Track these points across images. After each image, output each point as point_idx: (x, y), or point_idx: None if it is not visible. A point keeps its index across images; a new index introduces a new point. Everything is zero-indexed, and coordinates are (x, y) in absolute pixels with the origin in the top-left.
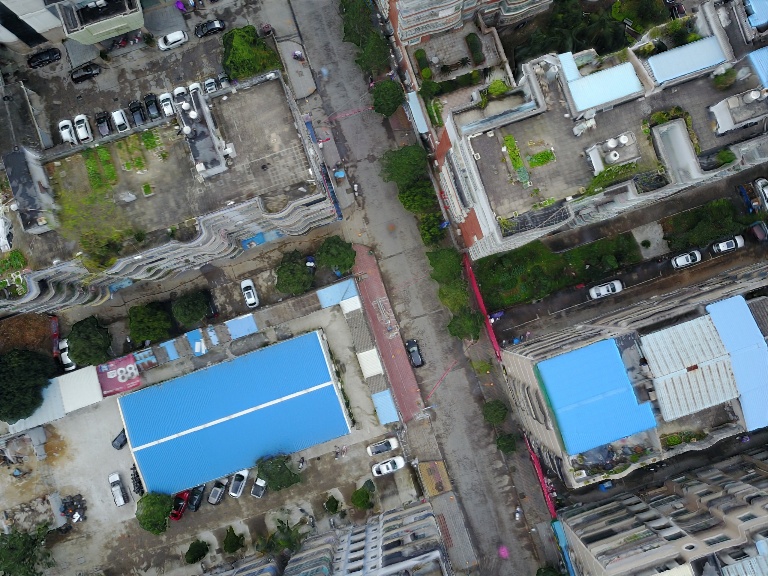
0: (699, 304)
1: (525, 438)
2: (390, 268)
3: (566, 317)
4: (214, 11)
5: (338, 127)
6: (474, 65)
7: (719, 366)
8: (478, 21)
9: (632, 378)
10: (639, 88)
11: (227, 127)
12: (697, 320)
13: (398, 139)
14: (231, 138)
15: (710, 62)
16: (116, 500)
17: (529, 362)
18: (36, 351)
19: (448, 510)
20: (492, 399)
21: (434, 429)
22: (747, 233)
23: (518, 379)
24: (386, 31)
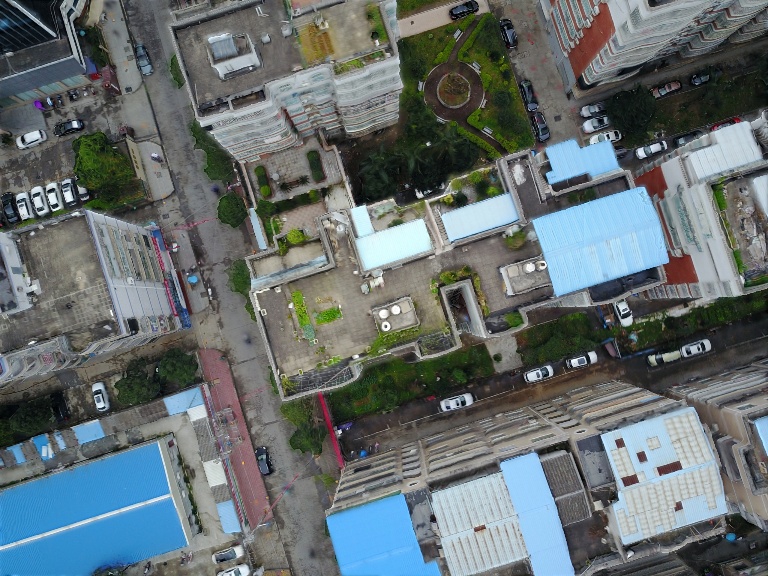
0: (497, 457)
1: None
2: (243, 373)
3: (417, 428)
4: (74, 110)
5: (195, 230)
6: (315, 183)
7: (507, 527)
8: (320, 138)
9: (422, 534)
10: (428, 247)
11: (33, 263)
12: (489, 477)
13: (255, 243)
14: (37, 274)
15: (503, 221)
16: None
17: None
18: None
19: None
20: None
21: (282, 537)
22: (601, 349)
23: None
24: None
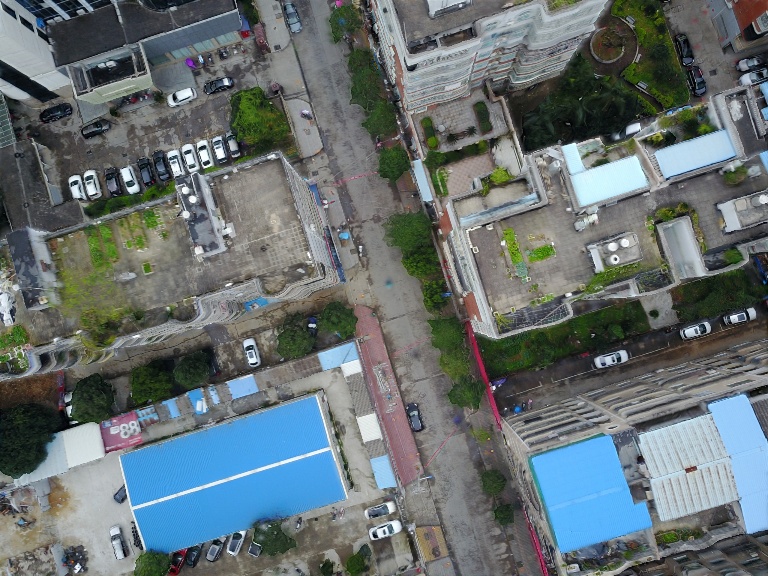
0: (701, 400)
1: (524, 509)
2: (393, 330)
3: (570, 385)
4: (223, 68)
5: (344, 187)
6: (481, 134)
7: (719, 468)
8: (486, 89)
9: (629, 476)
10: (644, 183)
11: (227, 206)
12: (698, 419)
13: (404, 200)
14: (231, 218)
15: (719, 157)
16: (116, 554)
17: (525, 452)
18: (42, 403)
19: (444, 575)
20: (492, 466)
21: (433, 494)
22: (760, 305)
23: (516, 457)
24: (393, 97)
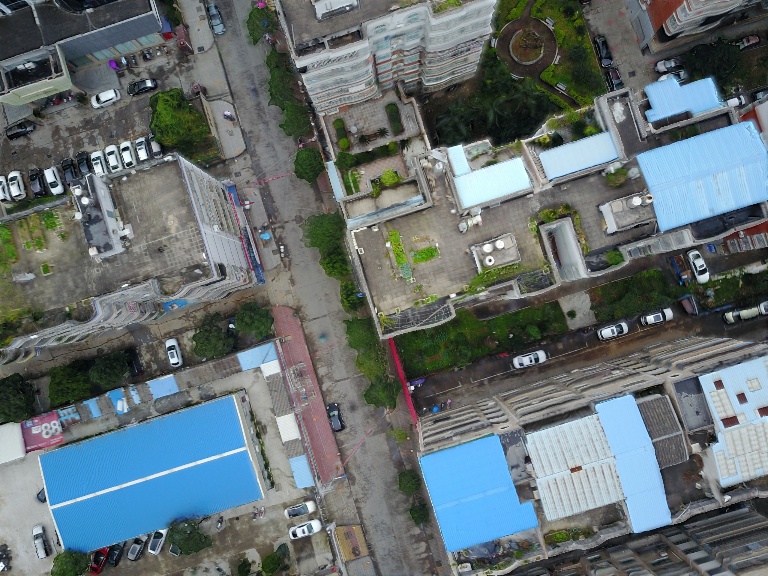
0: (591, 401)
1: None
2: (314, 330)
3: (489, 386)
4: (147, 69)
5: (266, 188)
6: (393, 135)
7: (604, 468)
8: (398, 91)
9: (517, 476)
10: (527, 185)
11: (126, 208)
12: (585, 419)
13: (326, 201)
14: (129, 219)
15: (602, 159)
16: (38, 553)
17: None
18: None
19: (364, 575)
20: (412, 465)
21: (353, 493)
22: (676, 306)
23: None
24: (307, 98)
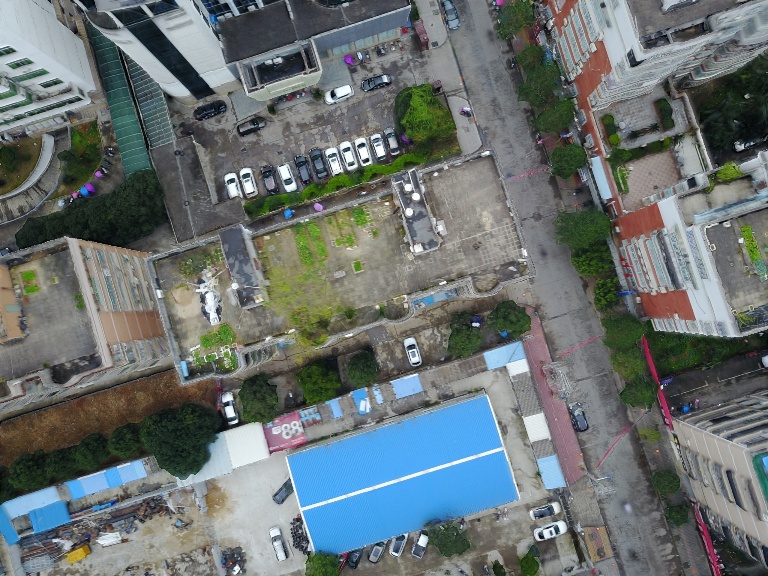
0: None
1: (697, 510)
2: (554, 329)
3: (736, 385)
4: (380, 65)
5: None
6: (662, 131)
7: None
8: (667, 86)
9: None
10: None
11: (438, 204)
12: None
13: (565, 198)
14: (442, 215)
15: None
16: (278, 555)
17: (744, 452)
18: (200, 403)
19: None
20: (657, 466)
21: (596, 494)
22: None
23: (706, 457)
24: (569, 94)
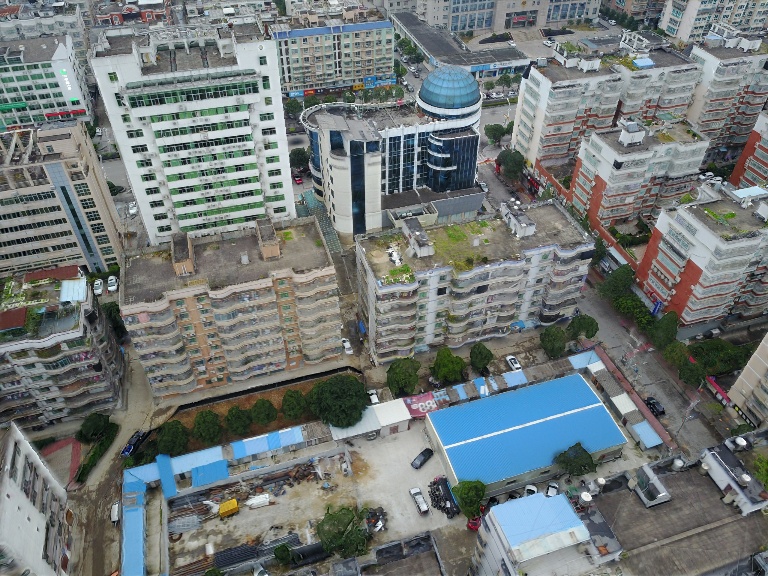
0: None
1: None
2: (615, 355)
3: None
4: None
5: None
6: None
7: None
8: (640, 219)
9: None
10: None
11: None
12: None
13: None
14: None
15: None
16: (420, 505)
17: None
18: None
19: None
20: None
21: None
22: None
23: (757, 381)
24: None
